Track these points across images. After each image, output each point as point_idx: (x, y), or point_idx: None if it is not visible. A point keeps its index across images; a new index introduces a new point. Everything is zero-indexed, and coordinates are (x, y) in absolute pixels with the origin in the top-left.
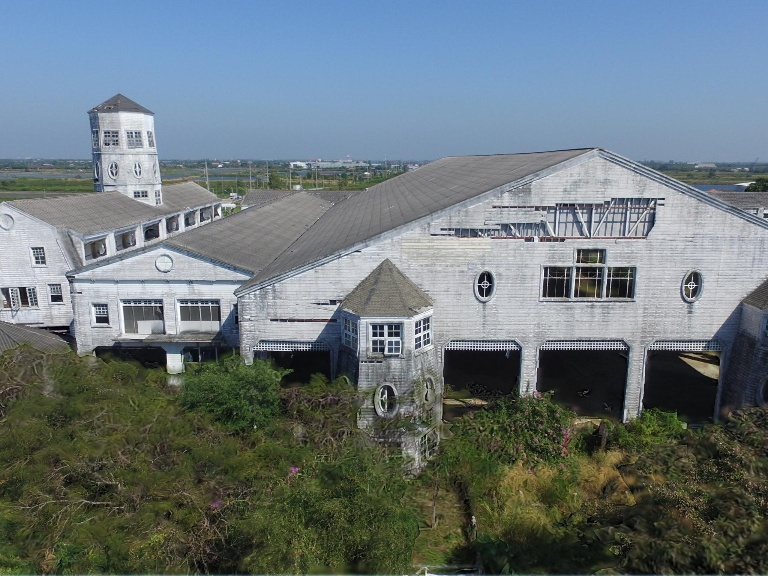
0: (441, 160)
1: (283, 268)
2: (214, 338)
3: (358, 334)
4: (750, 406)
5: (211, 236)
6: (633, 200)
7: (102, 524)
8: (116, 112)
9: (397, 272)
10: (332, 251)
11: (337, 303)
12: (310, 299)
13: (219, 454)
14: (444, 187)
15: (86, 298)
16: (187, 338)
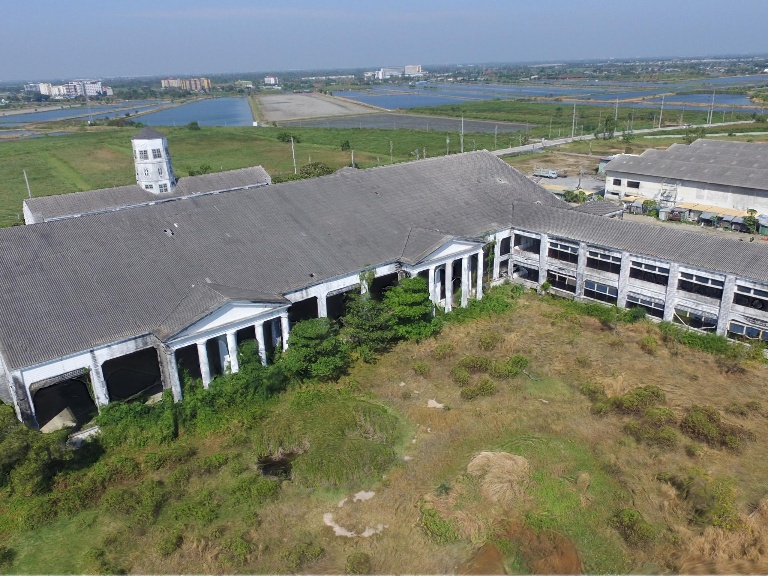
0: None
1: None
2: None
3: None
4: None
5: None
6: None
7: None
8: None
9: None
10: None
11: None
12: None
13: None
14: None
15: None
16: None
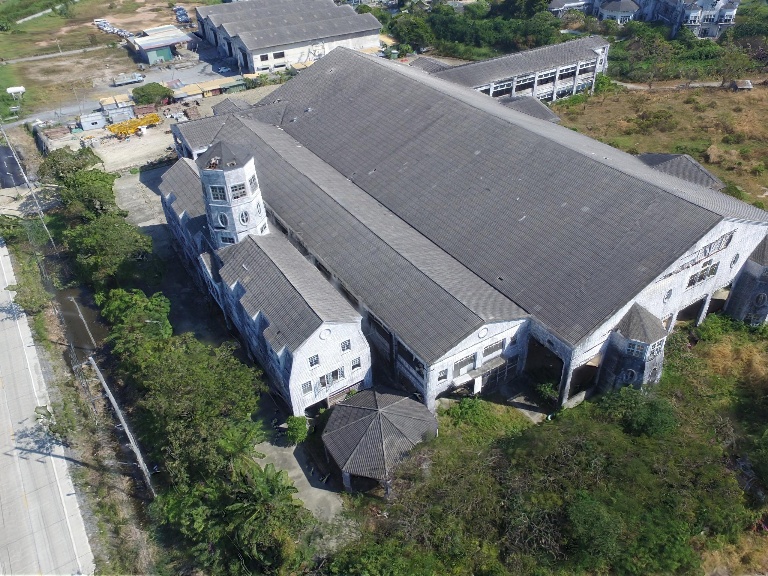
0: (365, 66)
1: (574, 319)
2: (505, 360)
3: (646, 352)
4: (750, 305)
5: (452, 287)
6: (727, 233)
7: (707, 498)
8: (241, 167)
9: (643, 308)
10: (610, 307)
11: (610, 331)
12: (601, 335)
13: (700, 450)
14: (563, 200)
15: (436, 371)
16: (493, 367)
